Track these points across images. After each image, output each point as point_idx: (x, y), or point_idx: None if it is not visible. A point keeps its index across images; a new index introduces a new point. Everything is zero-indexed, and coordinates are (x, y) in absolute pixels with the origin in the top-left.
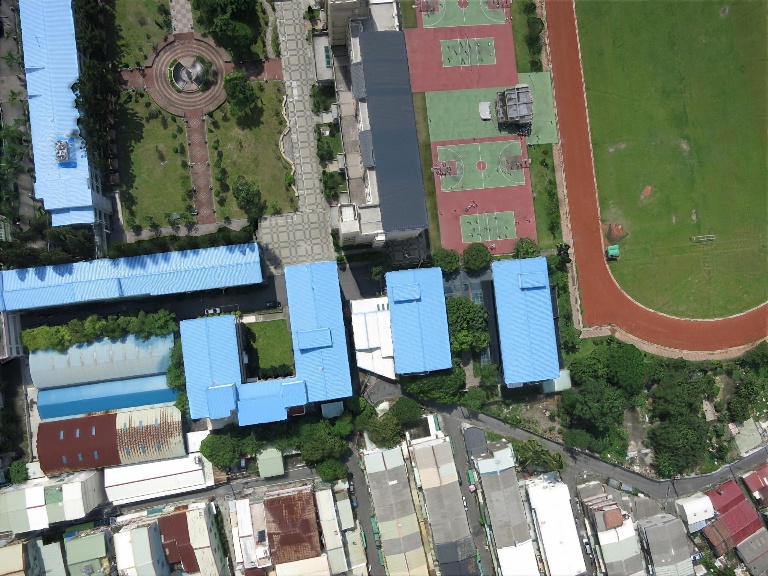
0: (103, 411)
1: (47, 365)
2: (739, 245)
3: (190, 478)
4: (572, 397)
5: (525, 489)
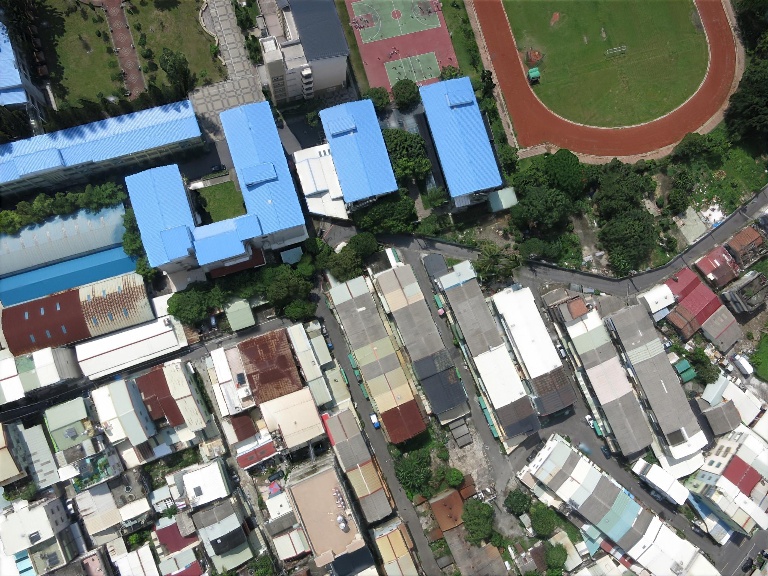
0: (65, 290)
1: (1, 250)
2: (650, 54)
3: (162, 341)
4: (520, 210)
5: (491, 304)
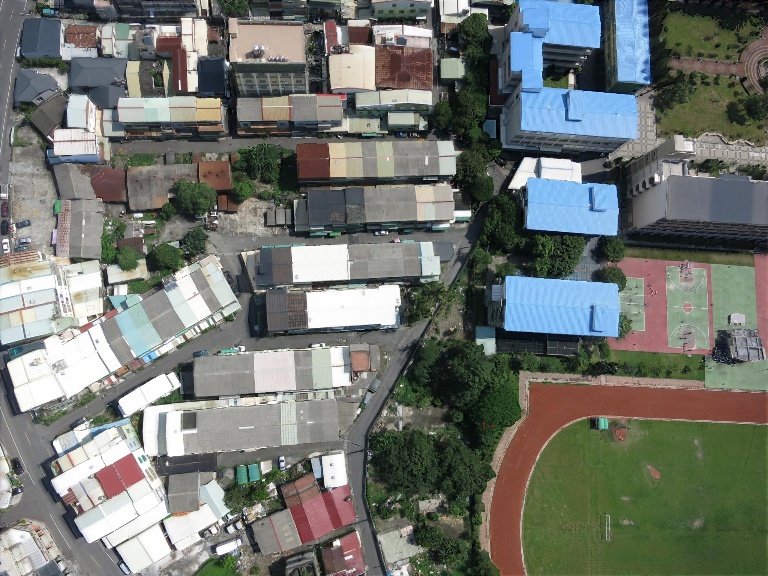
0: None
1: None
2: (594, 570)
3: (451, 3)
4: None
5: None
